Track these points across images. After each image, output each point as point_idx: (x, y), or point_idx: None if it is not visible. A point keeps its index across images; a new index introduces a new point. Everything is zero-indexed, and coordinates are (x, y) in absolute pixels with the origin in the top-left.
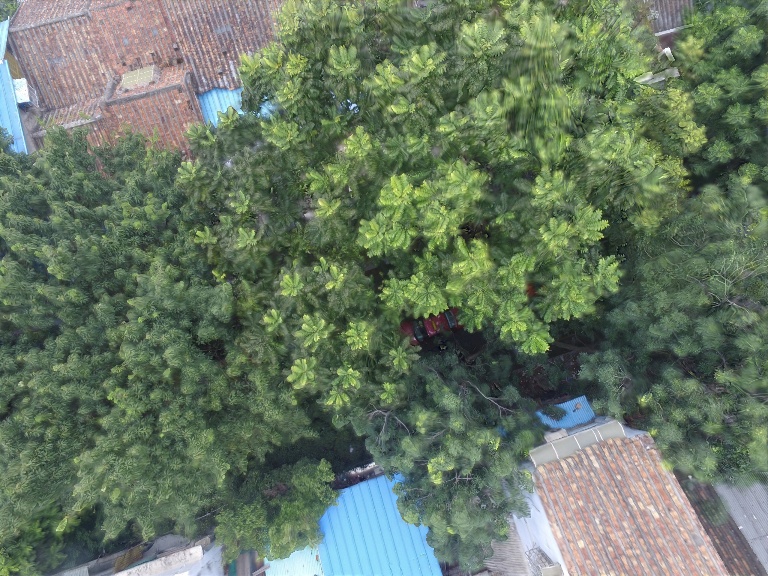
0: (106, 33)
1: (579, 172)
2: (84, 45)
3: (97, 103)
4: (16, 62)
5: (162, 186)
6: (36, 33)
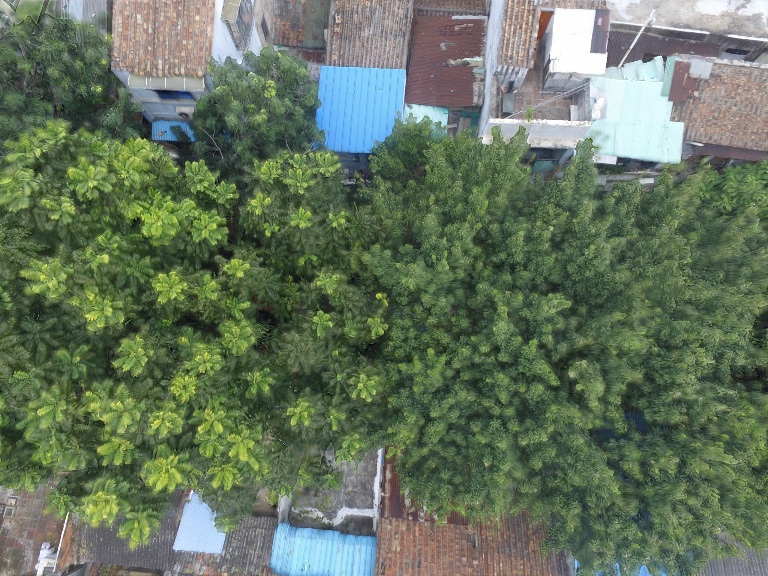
0: None
1: None
2: None
3: None
4: None
5: None
6: None
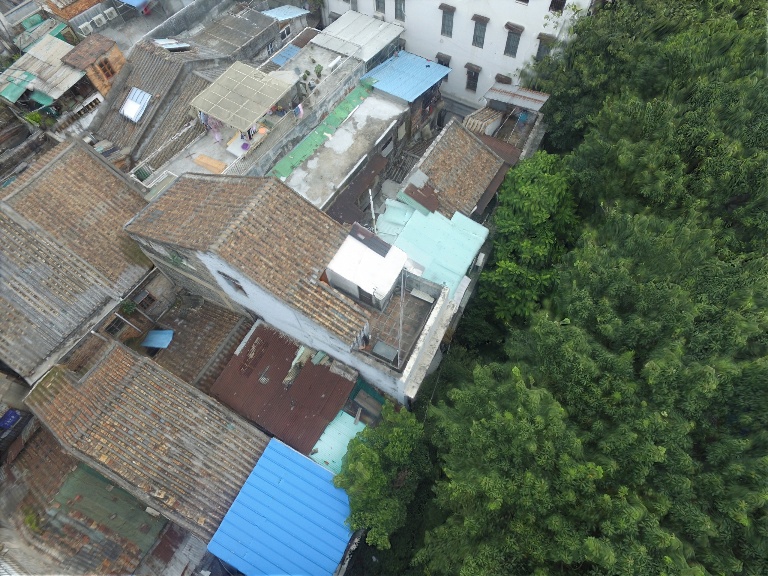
0: None
1: None
2: None
3: None
4: None
5: None
6: None
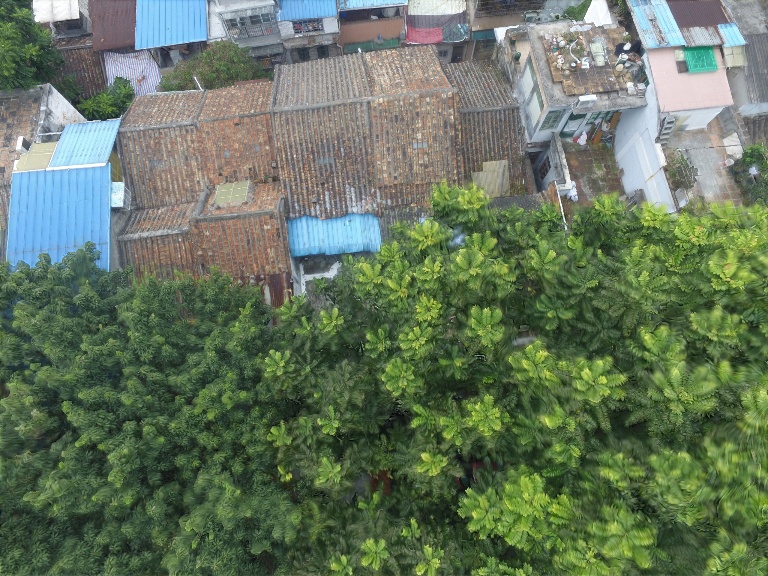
0: (210, 144)
1: (765, 531)
2: (186, 152)
3: (186, 211)
4: (118, 160)
5: (242, 358)
6: (143, 135)
